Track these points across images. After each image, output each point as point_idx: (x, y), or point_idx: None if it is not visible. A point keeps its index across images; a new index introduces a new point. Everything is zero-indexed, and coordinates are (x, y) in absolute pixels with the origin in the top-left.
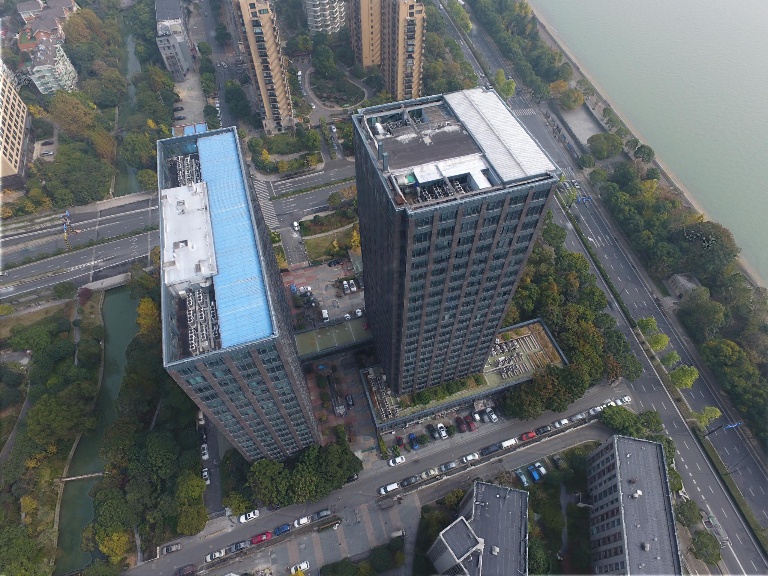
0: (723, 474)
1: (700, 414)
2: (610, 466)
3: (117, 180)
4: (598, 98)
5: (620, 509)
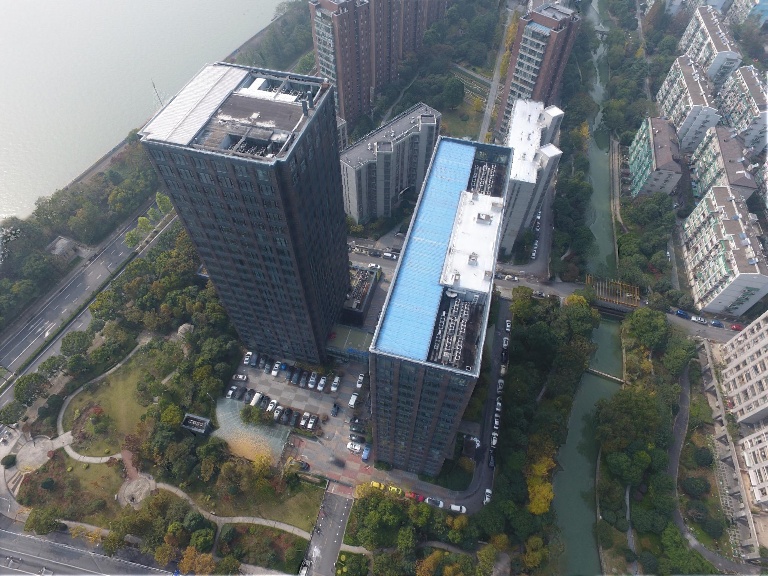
0: None
1: None
2: None
3: None
4: None
5: None
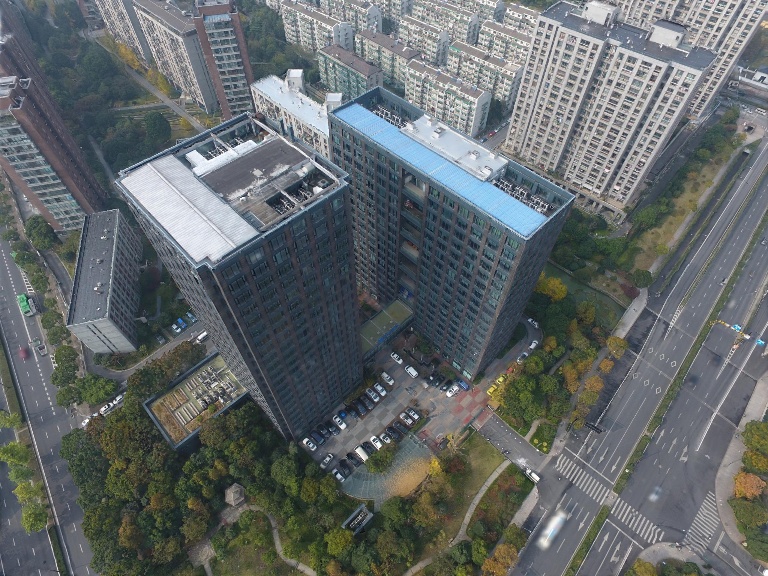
0: (11, 388)
1: (11, 428)
2: None
3: None
4: None
5: None
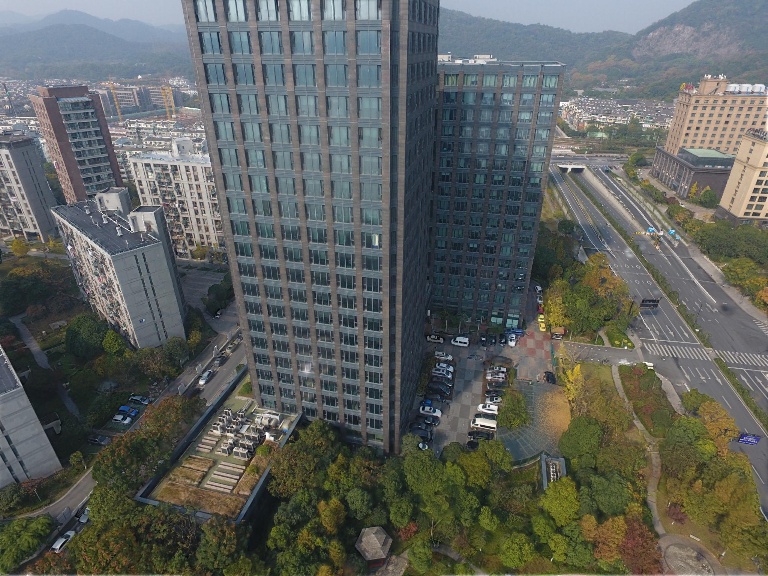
0: None
1: None
2: None
3: (760, 276)
4: None
5: None
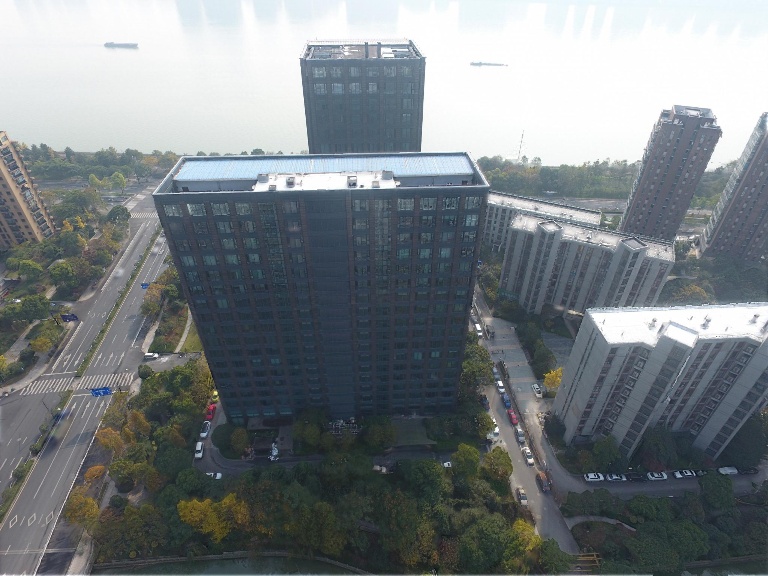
0: None
1: None
2: (490, 212)
3: None
4: (177, 158)
5: (517, 210)
